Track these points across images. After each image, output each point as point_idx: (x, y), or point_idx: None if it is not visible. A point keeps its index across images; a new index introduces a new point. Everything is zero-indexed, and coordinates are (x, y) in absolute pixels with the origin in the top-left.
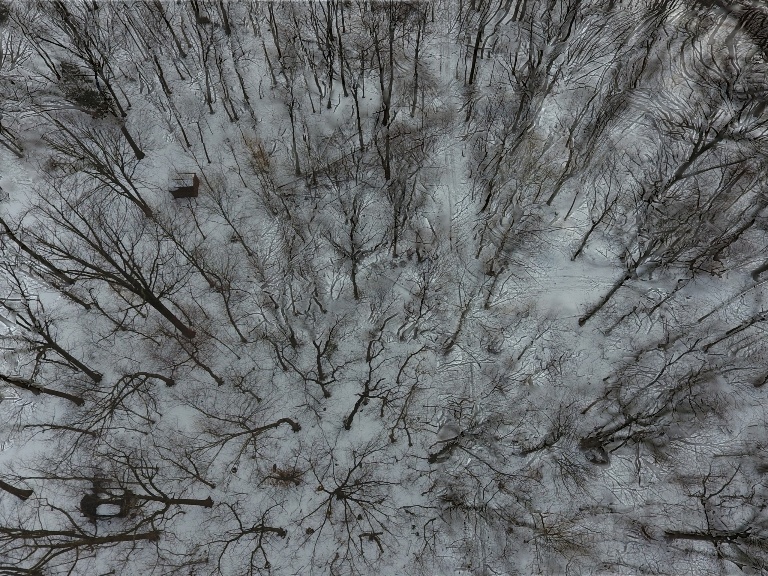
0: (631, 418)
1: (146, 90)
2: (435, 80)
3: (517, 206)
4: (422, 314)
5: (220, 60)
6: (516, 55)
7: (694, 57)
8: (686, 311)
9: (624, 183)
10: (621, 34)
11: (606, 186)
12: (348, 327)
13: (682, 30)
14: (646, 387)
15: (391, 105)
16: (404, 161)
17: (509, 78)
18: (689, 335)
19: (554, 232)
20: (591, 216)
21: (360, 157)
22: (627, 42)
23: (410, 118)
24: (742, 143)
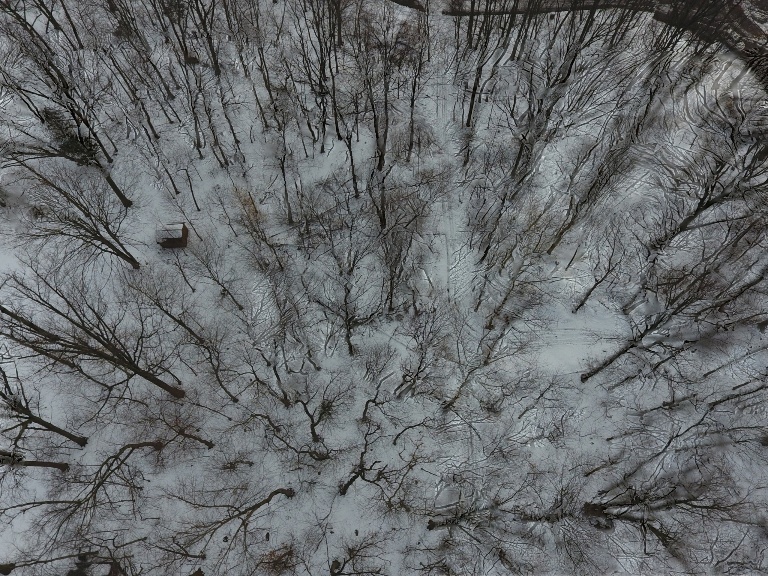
0: (638, 499)
1: (133, 135)
2: (431, 123)
3: (517, 256)
4: (419, 371)
5: (209, 110)
6: (515, 98)
7: (698, 102)
8: (691, 366)
9: (629, 246)
10: (623, 80)
11: (610, 248)
12: (343, 386)
13: (686, 76)
14: (652, 457)
15: (386, 151)
16: (400, 210)
17: (507, 121)
18: (694, 391)
19: (555, 283)
20: (594, 274)
21: (354, 217)
22: (629, 89)
23: (406, 163)
24: (748, 195)
